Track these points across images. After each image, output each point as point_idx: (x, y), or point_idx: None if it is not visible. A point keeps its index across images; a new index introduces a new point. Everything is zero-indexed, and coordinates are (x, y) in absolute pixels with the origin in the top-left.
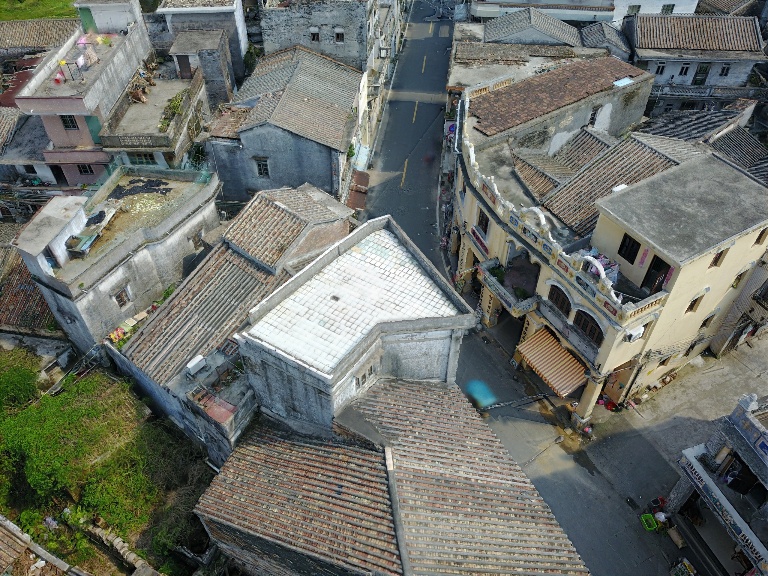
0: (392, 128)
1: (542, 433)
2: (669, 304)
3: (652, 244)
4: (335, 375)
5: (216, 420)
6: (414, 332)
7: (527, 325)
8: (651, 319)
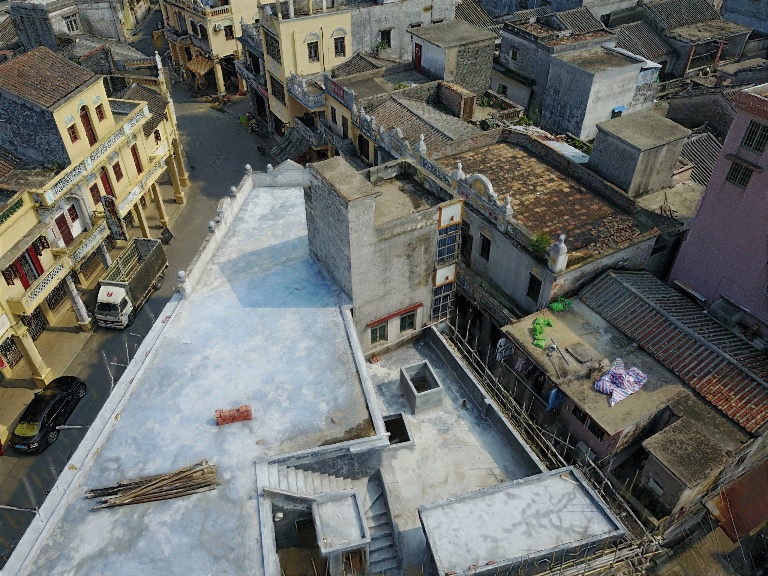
0: (154, 20)
1: (203, 105)
2: (236, 14)
3: None
4: (49, 6)
5: (4, 54)
6: (91, 3)
7: (193, 57)
8: (230, 23)
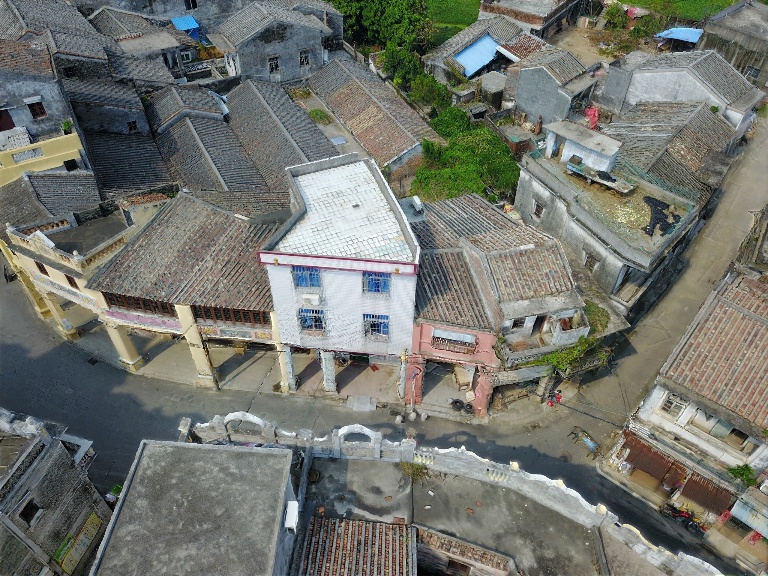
0: None
1: None
2: None
3: None
4: None
5: None
6: None
7: None
8: None
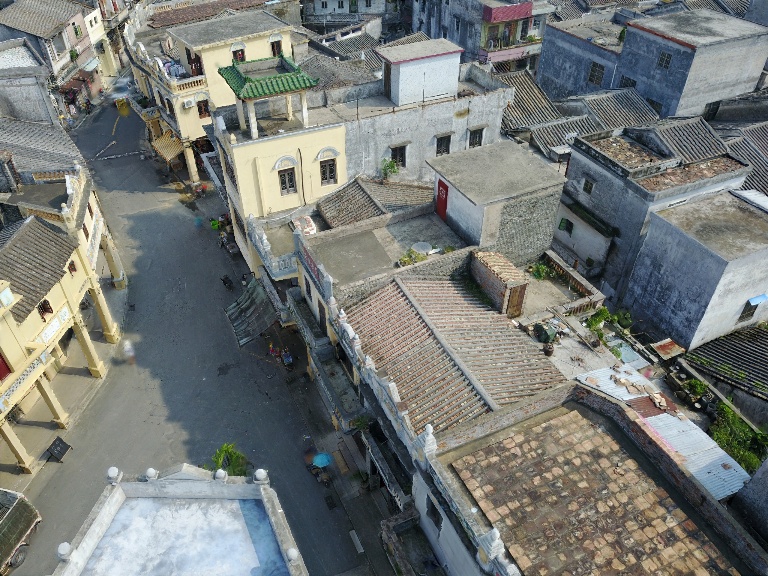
0: None
1: (171, 197)
2: (213, 86)
3: (184, 42)
4: None
5: None
6: (11, 78)
7: (163, 133)
8: (205, 97)
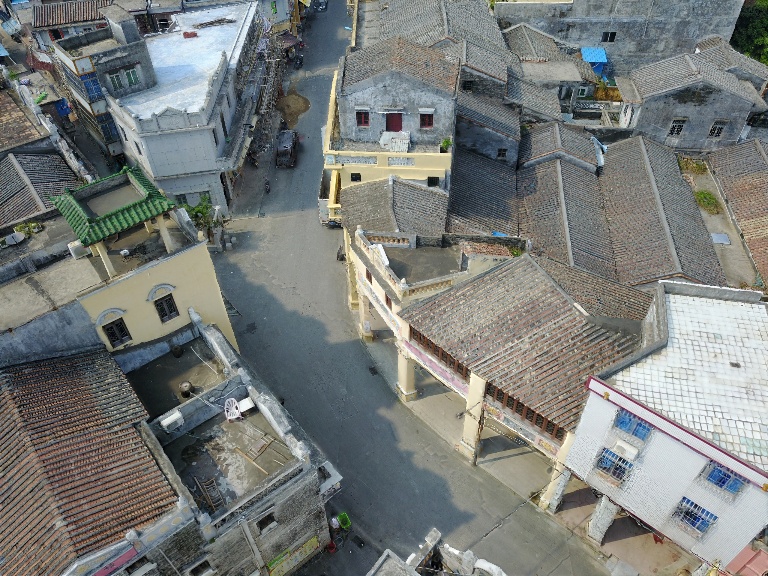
0: None
1: None
2: None
3: None
4: None
5: None
6: None
7: None
8: None
